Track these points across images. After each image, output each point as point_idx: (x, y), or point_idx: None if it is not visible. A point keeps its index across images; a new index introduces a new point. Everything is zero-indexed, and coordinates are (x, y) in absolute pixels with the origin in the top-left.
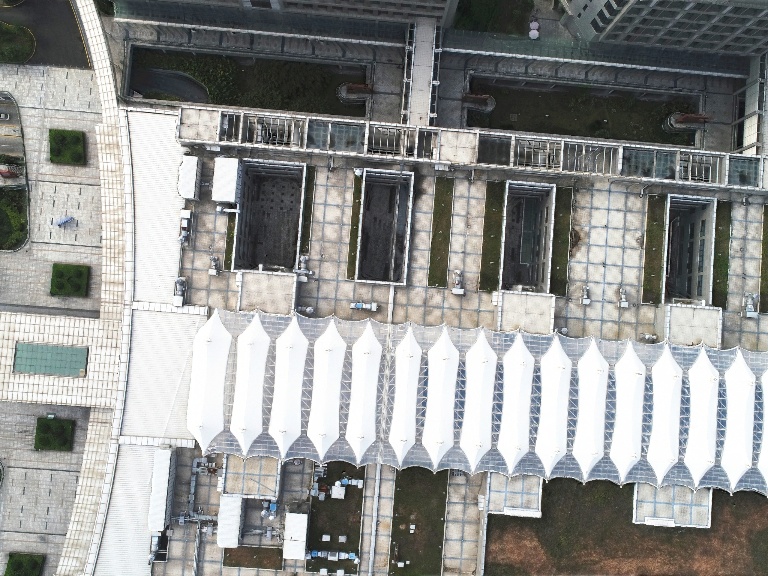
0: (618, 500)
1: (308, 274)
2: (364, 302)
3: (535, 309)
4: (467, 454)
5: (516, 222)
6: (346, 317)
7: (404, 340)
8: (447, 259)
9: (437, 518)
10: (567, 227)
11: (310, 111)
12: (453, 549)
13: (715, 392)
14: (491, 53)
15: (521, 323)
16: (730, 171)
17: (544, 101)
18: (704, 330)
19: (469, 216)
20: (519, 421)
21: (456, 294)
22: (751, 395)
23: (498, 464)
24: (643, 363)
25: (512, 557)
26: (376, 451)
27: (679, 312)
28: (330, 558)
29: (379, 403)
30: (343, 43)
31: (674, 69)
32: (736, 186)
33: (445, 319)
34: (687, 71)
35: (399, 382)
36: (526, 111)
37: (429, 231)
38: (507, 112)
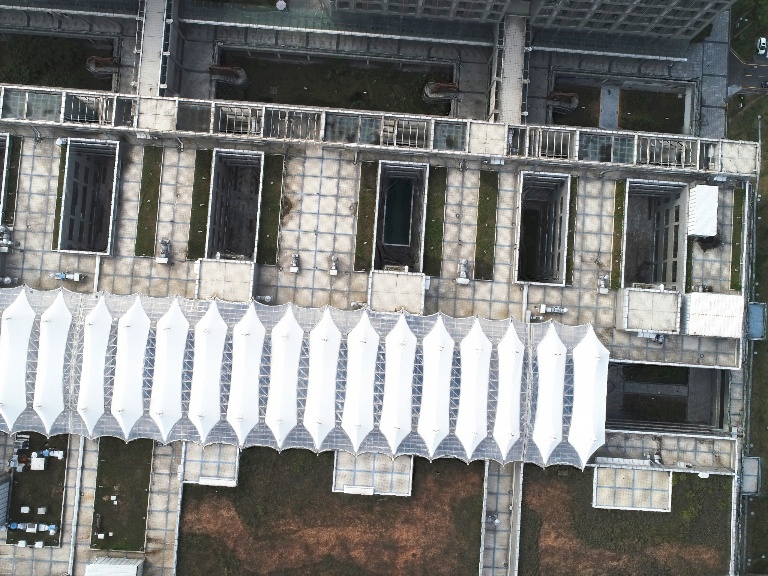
0: (318, 469)
1: (9, 245)
2: (69, 272)
3: (234, 277)
4: (157, 423)
5: (254, 193)
6: (51, 288)
7: (94, 309)
8: (155, 228)
9: (141, 489)
10: (278, 195)
11: (58, 86)
12: (158, 520)
13: (409, 358)
14: (231, 24)
15: (220, 291)
16: (436, 136)
17: (304, 73)
18: (407, 296)
19: (178, 185)
20: (206, 389)
21: (160, 263)
22: (445, 360)
23: (190, 433)
24: (339, 330)
25: (208, 527)
26: (65, 421)
27: (382, 278)
28: (28, 530)
29: (67, 372)
30: (82, 16)
31: (418, 38)
32: (441, 151)
33: (151, 289)
34: (432, 39)
35: (85, 351)
36: (285, 84)
37: (137, 200)
38: (266, 85)
